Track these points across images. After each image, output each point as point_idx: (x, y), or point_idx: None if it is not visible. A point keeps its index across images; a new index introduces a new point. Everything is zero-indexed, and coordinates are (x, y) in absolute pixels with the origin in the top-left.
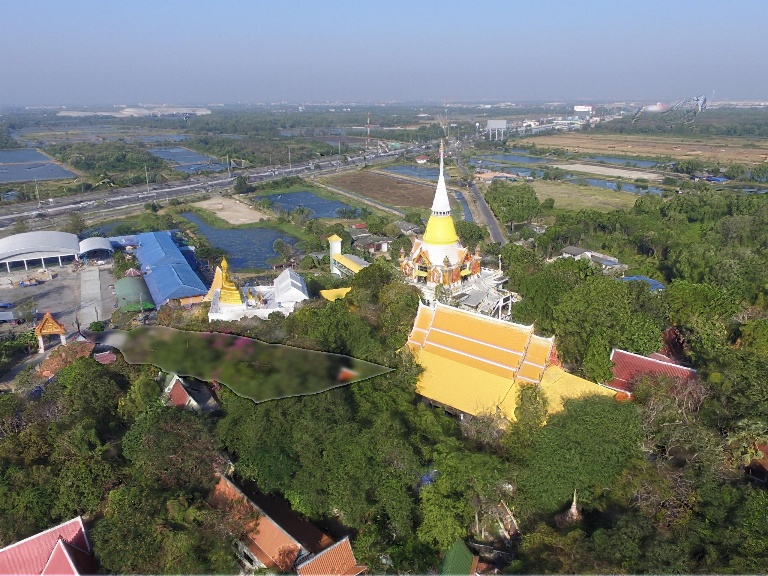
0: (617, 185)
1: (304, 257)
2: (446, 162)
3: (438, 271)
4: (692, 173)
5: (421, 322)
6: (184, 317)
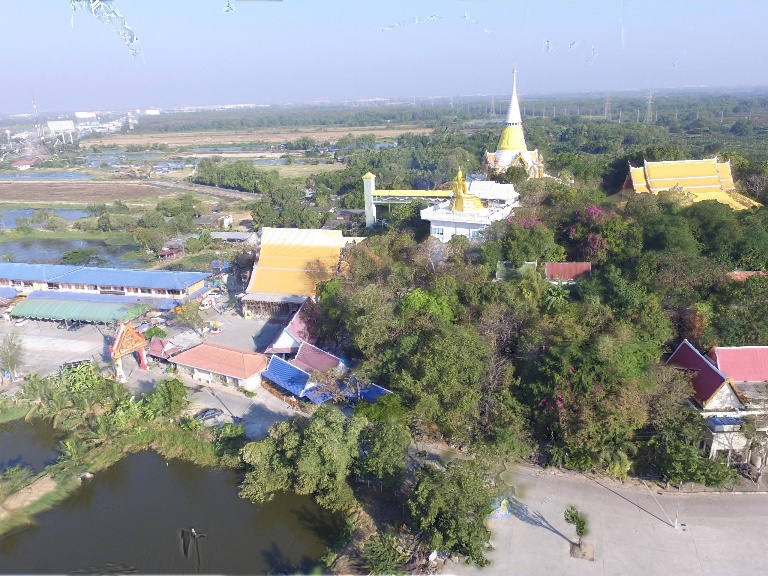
0: (288, 159)
1: (188, 240)
2: (59, 165)
3: (536, 168)
4: (308, 149)
5: (637, 179)
6: (431, 237)
